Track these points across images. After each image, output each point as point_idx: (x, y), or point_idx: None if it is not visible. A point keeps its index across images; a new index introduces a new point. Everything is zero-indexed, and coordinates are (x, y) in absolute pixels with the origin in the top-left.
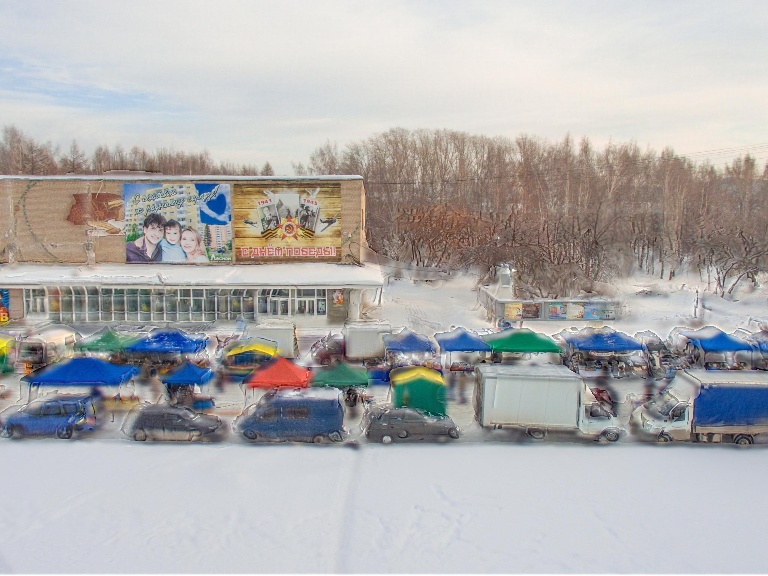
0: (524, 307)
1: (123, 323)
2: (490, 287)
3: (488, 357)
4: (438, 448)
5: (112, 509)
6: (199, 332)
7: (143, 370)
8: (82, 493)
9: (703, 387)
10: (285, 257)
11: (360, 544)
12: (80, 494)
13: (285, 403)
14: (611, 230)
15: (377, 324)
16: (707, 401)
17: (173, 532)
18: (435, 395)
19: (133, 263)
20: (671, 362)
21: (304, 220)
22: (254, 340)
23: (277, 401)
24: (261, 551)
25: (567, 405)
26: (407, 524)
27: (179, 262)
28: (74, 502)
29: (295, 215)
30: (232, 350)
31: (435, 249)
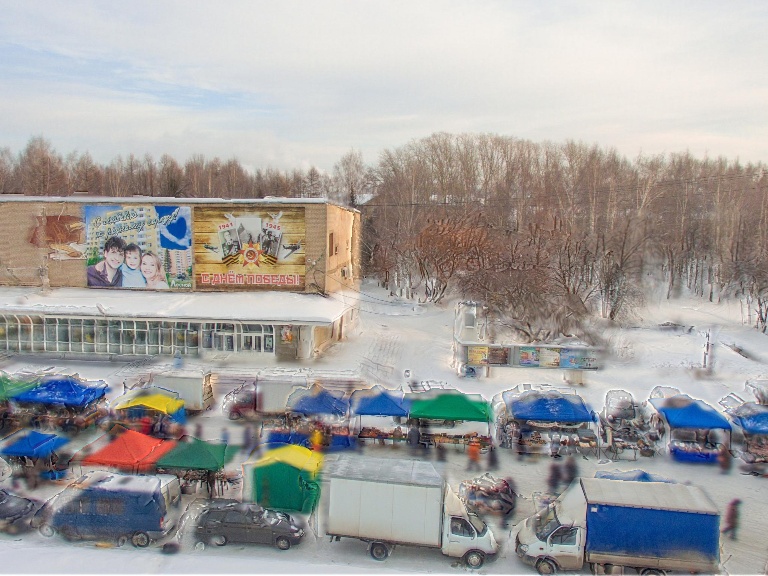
0: (490, 351)
1: (67, 354)
2: (455, 327)
3: (403, 423)
4: (238, 570)
5: None
6: (131, 369)
7: (27, 421)
8: None
9: (589, 509)
10: (246, 285)
11: None
12: None
13: (84, 497)
14: (640, 251)
15: (292, 376)
16: (598, 526)
17: None
18: (294, 482)
19: (94, 288)
20: (625, 439)
21: (266, 246)
22: (150, 391)
23: (76, 494)
24: None
25: (427, 515)
26: None
27: (139, 288)
28: None
29: (257, 240)
30: (119, 404)
31: (442, 269)
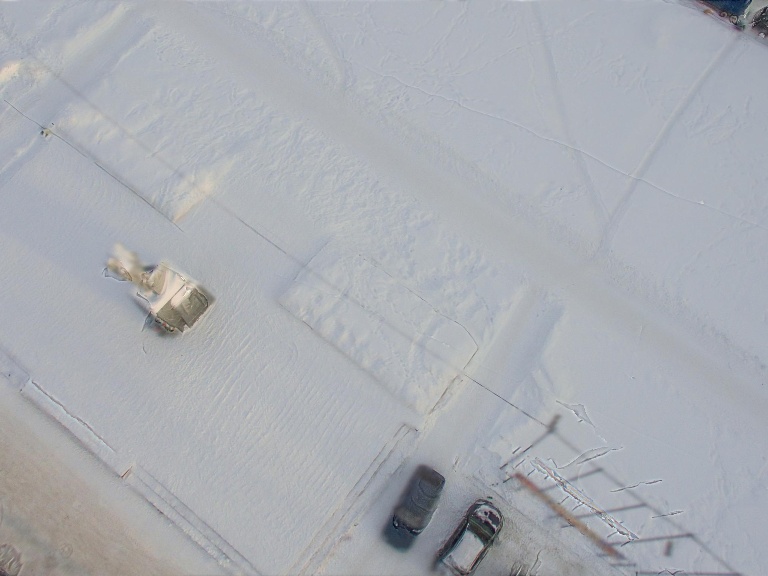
0: None
1: None
2: None
3: None
4: None
5: (603, 35)
6: None
7: None
8: (593, 12)
9: None
10: None
11: (690, 116)
12: (592, 13)
13: None
14: None
15: None
16: None
17: (623, 66)
18: None
19: None
20: None
21: None
22: None
23: None
24: (651, 98)
25: None
26: (717, 115)
27: None
28: (589, 19)
29: None
30: None
31: None
